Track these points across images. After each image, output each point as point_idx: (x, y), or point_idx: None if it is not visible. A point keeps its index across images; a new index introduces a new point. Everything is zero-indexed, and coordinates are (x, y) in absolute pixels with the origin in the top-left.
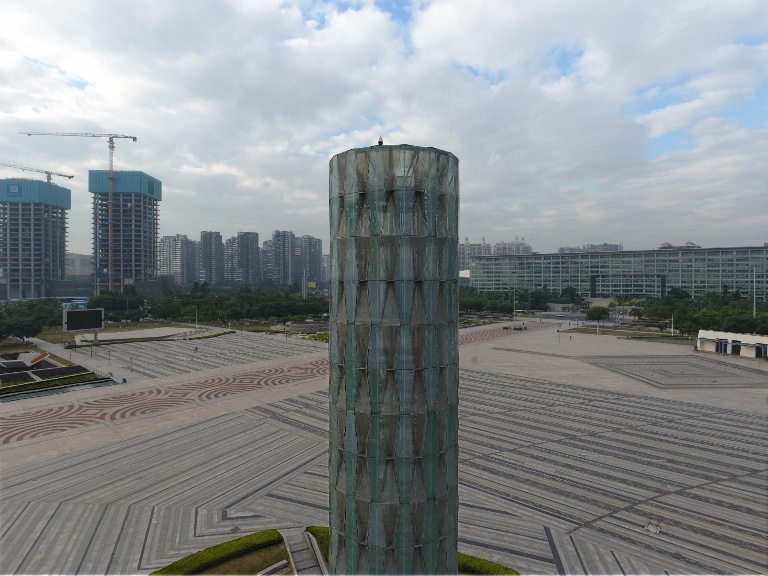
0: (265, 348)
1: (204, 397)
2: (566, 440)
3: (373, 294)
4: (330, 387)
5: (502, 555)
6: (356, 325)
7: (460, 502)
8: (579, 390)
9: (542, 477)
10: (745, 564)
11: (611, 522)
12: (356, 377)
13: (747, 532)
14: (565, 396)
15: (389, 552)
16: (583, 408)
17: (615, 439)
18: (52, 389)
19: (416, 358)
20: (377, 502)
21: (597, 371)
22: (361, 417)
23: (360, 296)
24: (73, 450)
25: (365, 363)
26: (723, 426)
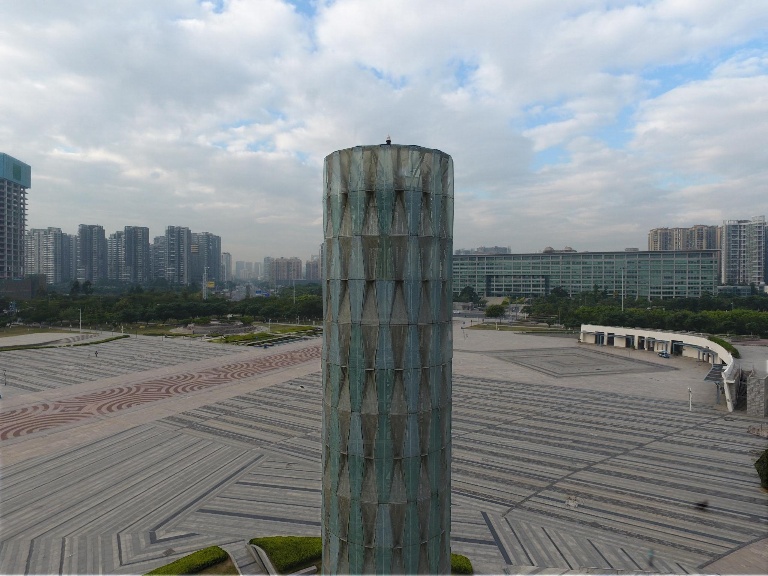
0: (168, 353)
1: (105, 410)
2: (486, 429)
3: (380, 294)
4: (326, 390)
5: None
6: (362, 325)
7: None
8: (490, 382)
9: (471, 466)
10: (647, 525)
11: (537, 501)
12: (362, 378)
13: (644, 497)
14: (479, 389)
15: (397, 552)
16: (496, 399)
17: (528, 425)
18: None
19: (422, 357)
20: (385, 503)
21: (502, 364)
22: (367, 419)
23: (366, 296)
24: None
25: (372, 364)
26: (611, 408)
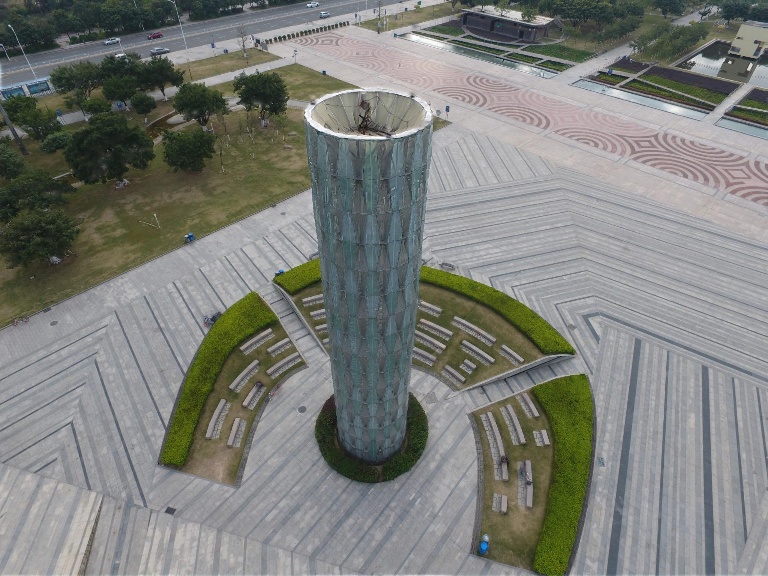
0: None
1: None
2: None
3: None
4: None
5: (598, 574)
6: None
7: (714, 554)
8: None
9: None
10: None
11: None
12: None
13: None
14: None
15: None
16: None
17: None
18: None
19: None
20: None
21: None
22: None
23: None
24: (652, 197)
25: None
26: None
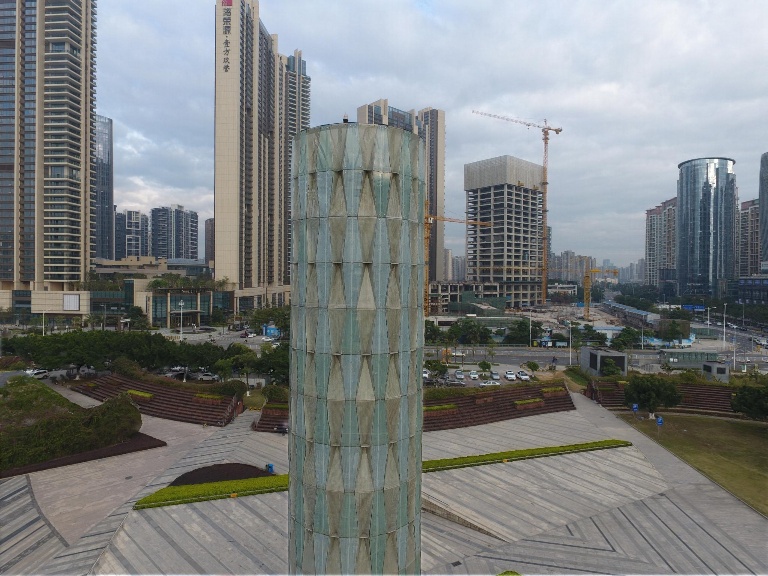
0: None
1: None
2: None
3: None
4: (409, 381)
5: None
6: None
7: None
8: None
9: None
10: None
11: None
12: None
13: None
14: None
15: None
16: None
17: None
18: None
19: None
20: None
21: None
22: None
23: None
24: None
25: None
26: None
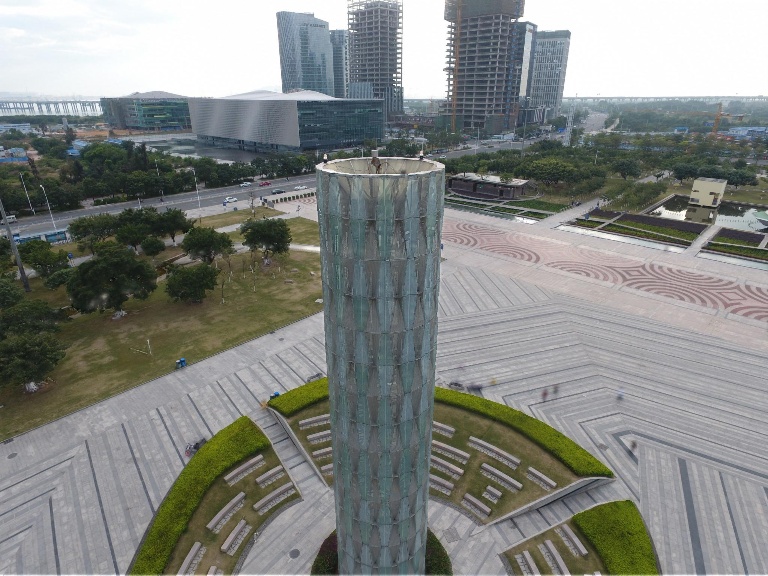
0: None
1: None
2: None
3: None
4: None
5: None
6: None
7: None
8: None
9: None
10: None
11: None
12: None
13: None
14: None
15: None
16: None
17: None
18: (751, 260)
19: None
20: None
21: None
22: None
23: None
24: (654, 317)
25: None
26: None
